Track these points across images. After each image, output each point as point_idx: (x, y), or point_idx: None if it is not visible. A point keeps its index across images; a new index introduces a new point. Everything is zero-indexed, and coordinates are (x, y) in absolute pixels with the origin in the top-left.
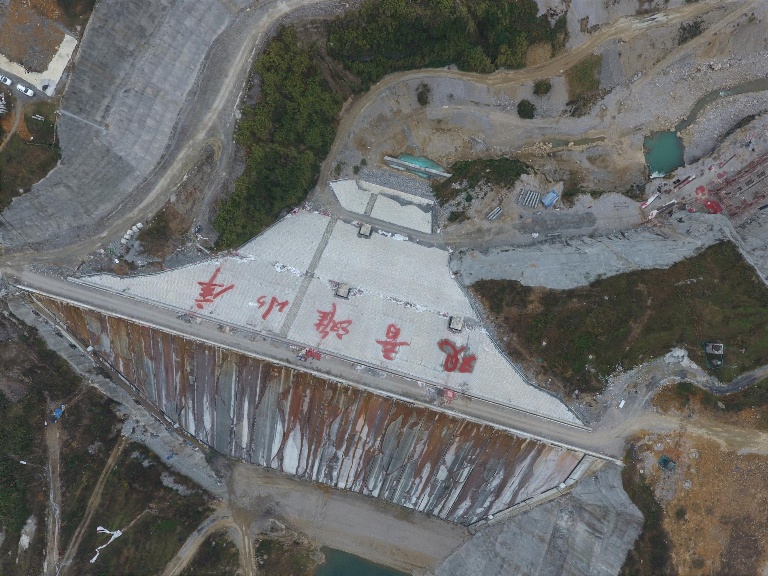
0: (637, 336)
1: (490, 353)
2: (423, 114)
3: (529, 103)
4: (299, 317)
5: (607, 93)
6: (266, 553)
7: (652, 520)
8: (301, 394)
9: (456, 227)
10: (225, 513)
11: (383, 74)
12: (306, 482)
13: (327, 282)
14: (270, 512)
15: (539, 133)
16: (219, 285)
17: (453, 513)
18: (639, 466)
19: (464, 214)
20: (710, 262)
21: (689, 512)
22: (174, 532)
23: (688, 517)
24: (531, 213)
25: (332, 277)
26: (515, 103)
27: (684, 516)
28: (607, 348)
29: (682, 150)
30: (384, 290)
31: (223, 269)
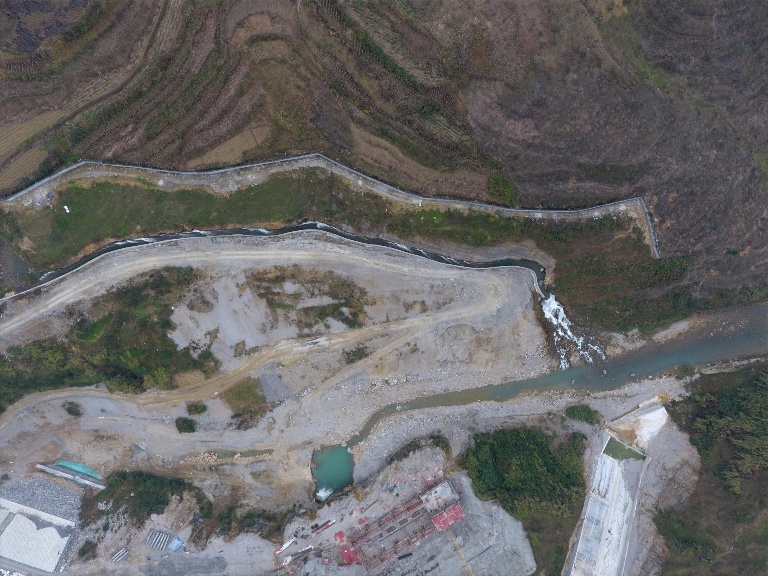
0: None
1: None
2: (76, 425)
3: (185, 421)
4: None
5: (276, 405)
6: None
7: None
8: None
9: (80, 566)
10: None
11: (20, 396)
12: None
13: None
14: None
15: (202, 445)
16: None
17: None
18: None
19: (95, 548)
20: None
21: None
22: None
23: None
24: (159, 555)
25: None
26: (173, 418)
27: None
28: None
29: (352, 466)
30: None
31: None
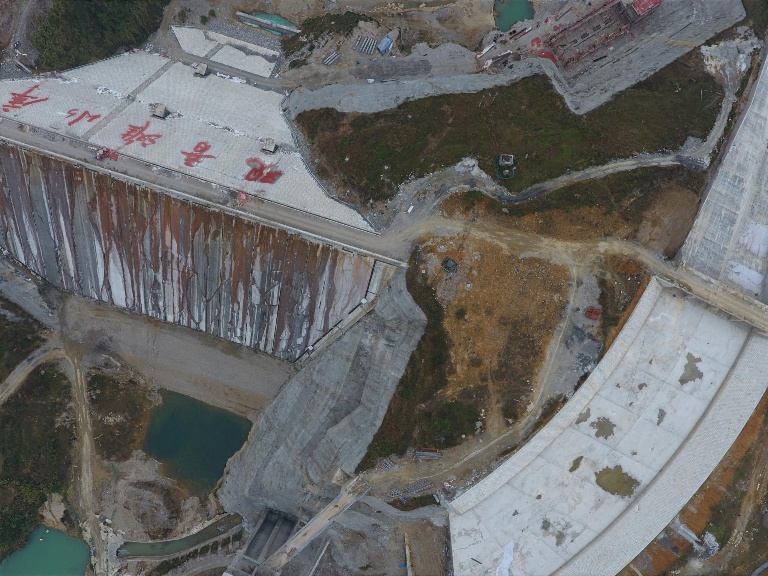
0: (433, 149)
1: (298, 172)
2: None
3: None
4: (107, 127)
5: None
6: (99, 388)
7: (433, 320)
8: (107, 203)
9: (294, 72)
10: (57, 345)
11: None
12: (136, 315)
13: (147, 105)
14: (104, 347)
15: None
16: (32, 97)
17: (277, 347)
18: (422, 267)
19: (304, 61)
20: (520, 91)
21: (469, 312)
22: (2, 357)
23: (468, 317)
24: (368, 59)
25: (153, 101)
26: None
27: (464, 316)
28: (403, 159)
29: (532, 14)
30: (204, 115)
31: (42, 86)
